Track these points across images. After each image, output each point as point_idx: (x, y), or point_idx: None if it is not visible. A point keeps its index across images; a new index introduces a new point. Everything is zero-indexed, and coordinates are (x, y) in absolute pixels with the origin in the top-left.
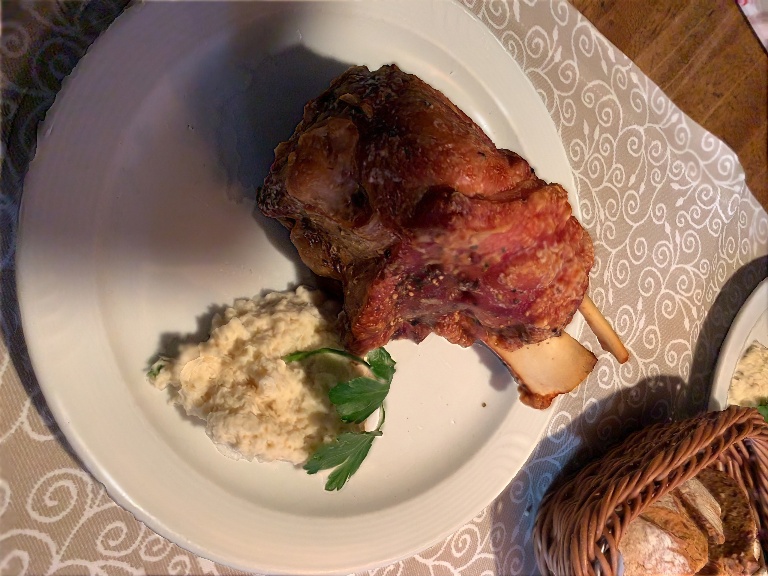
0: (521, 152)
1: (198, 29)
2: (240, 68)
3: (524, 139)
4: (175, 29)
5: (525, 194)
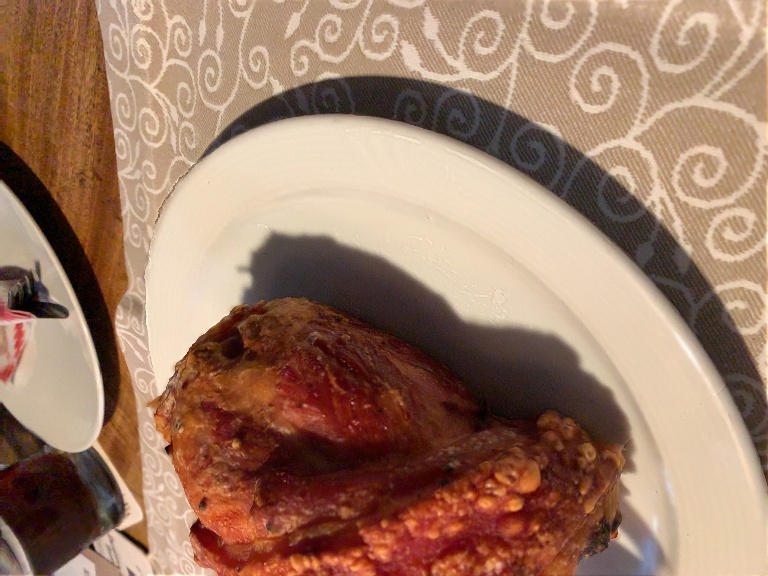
0: (582, 325)
1: (186, 264)
2: (240, 270)
3: (576, 307)
4: (174, 270)
5: (251, 559)
